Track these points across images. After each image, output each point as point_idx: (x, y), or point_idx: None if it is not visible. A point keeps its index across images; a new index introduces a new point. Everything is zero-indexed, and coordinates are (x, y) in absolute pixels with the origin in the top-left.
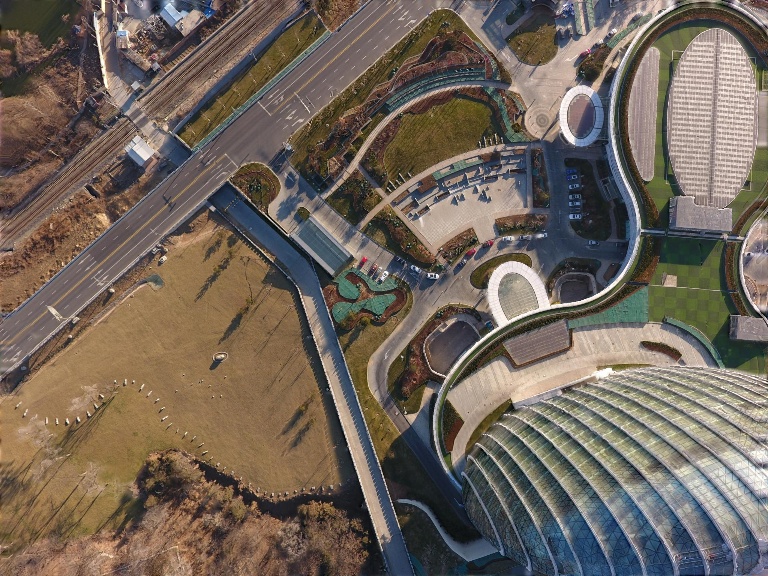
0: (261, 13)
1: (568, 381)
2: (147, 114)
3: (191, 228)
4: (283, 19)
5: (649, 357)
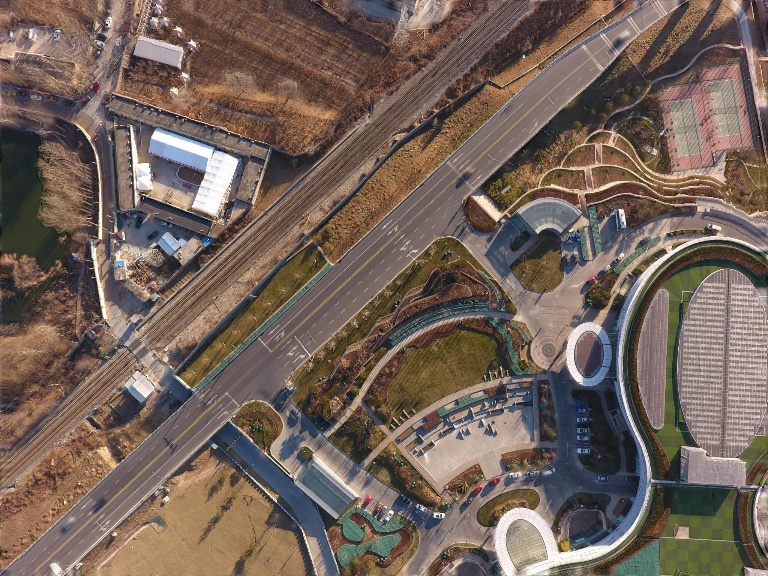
0: (260, 237)
1: None
2: (147, 344)
3: (193, 466)
4: (282, 258)
5: None
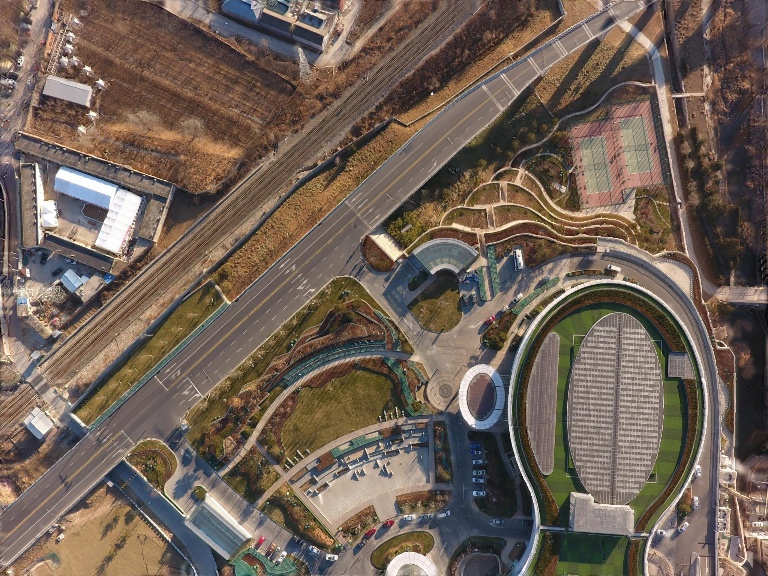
0: (163, 274)
1: None
2: (48, 380)
3: (89, 504)
4: (178, 297)
5: None
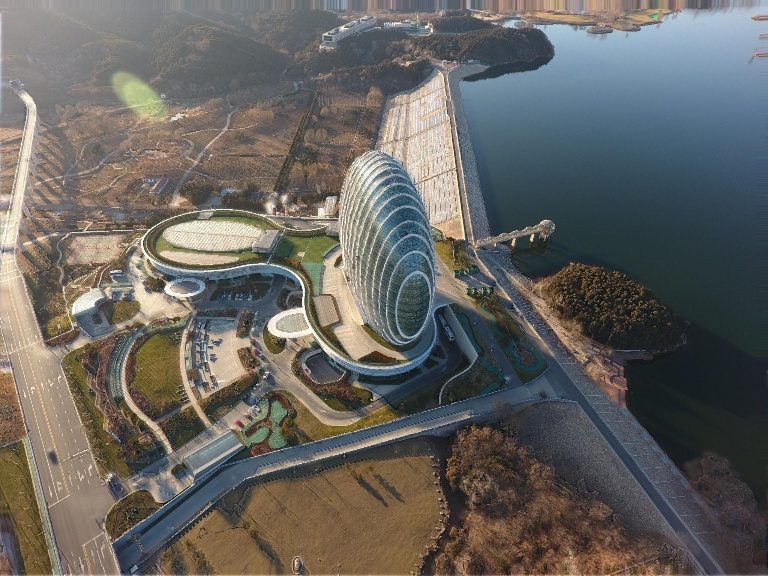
0: None
1: None
2: None
3: None
4: None
5: None
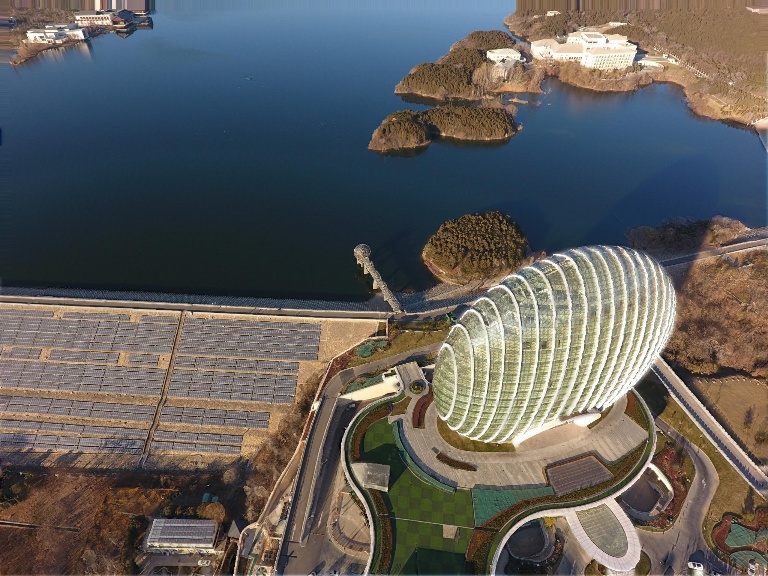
0: None
1: (541, 440)
2: None
3: None
4: None
5: (467, 457)
